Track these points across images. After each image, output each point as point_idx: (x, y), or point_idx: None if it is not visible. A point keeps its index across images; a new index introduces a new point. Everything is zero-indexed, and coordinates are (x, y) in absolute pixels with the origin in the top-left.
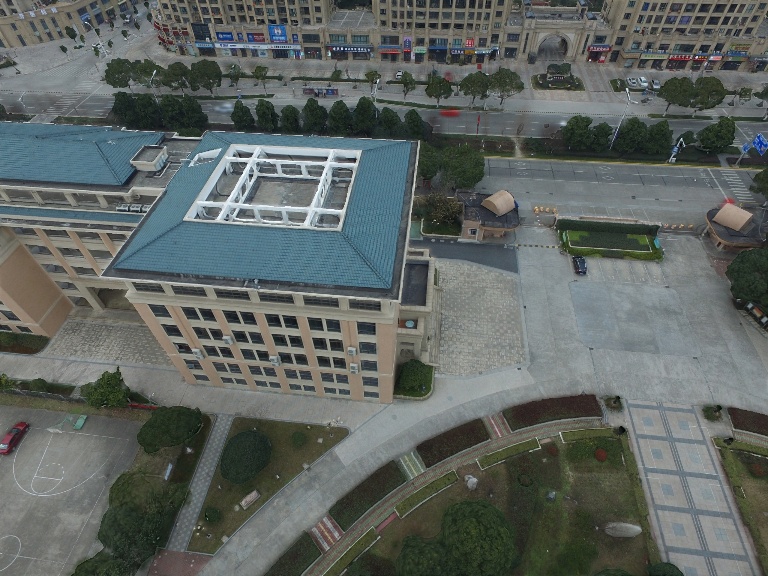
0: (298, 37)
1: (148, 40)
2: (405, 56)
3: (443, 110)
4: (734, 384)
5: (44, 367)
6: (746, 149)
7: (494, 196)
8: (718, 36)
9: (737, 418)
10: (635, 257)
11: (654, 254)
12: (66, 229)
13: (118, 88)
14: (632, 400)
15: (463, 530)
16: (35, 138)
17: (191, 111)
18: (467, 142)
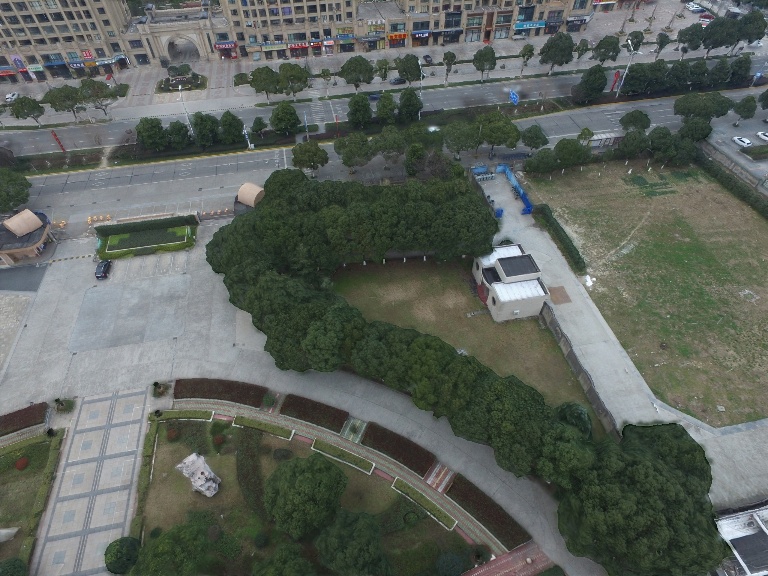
0: None
1: None
2: (25, 76)
3: (46, 129)
4: (198, 355)
5: None
6: (305, 127)
7: (12, 217)
8: (320, 23)
9: (177, 389)
10: (166, 250)
11: (186, 243)
12: None
13: None
14: (89, 397)
15: None
16: None
17: None
18: (51, 160)
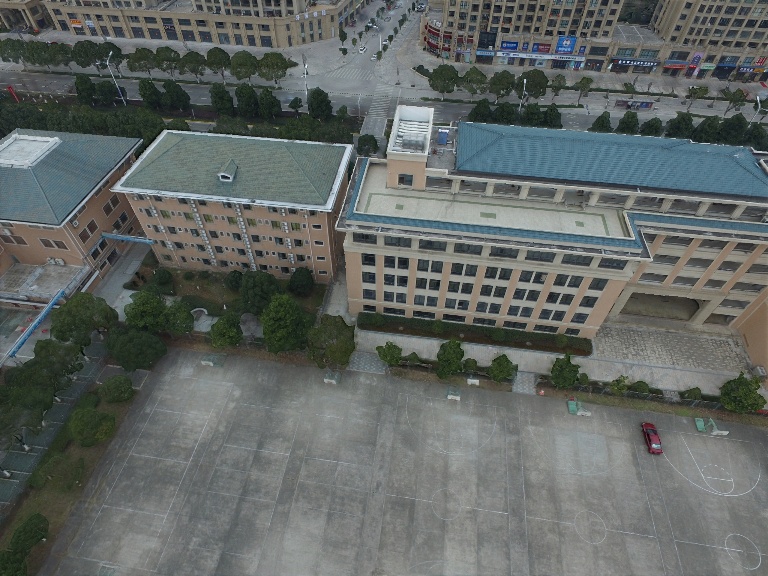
0: (585, 49)
1: (406, 45)
2: (687, 71)
3: (765, 127)
4: None
5: (609, 369)
6: None
7: None
8: None
9: None
10: None
11: None
12: (714, 238)
13: (420, 93)
14: None
15: None
16: (663, 149)
17: (555, 120)
18: None
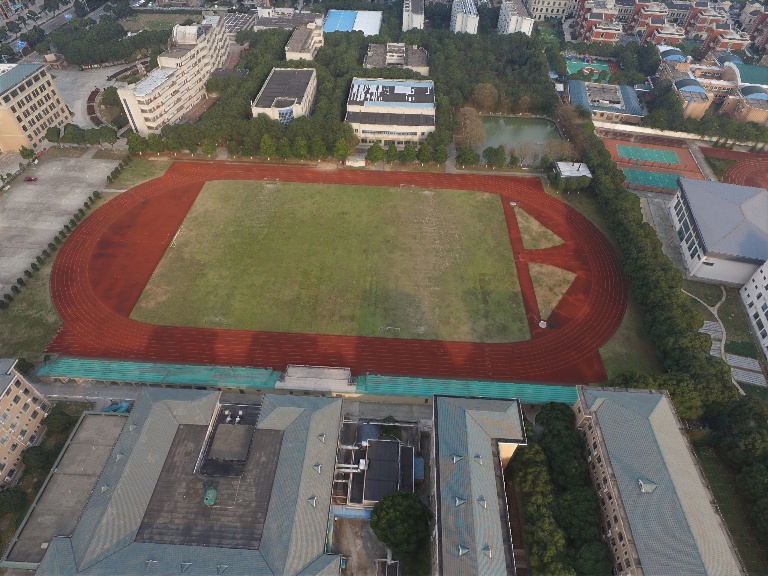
0: None
1: None
2: None
3: None
4: (104, 76)
5: None
6: (20, 49)
7: None
8: None
9: (112, 77)
10: None
11: None
12: None
13: None
14: None
15: (109, 89)
16: None
17: None
18: None
